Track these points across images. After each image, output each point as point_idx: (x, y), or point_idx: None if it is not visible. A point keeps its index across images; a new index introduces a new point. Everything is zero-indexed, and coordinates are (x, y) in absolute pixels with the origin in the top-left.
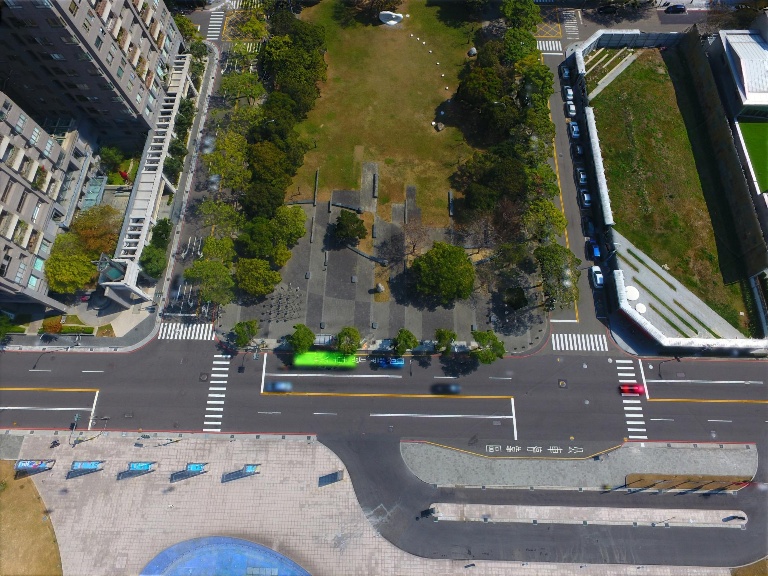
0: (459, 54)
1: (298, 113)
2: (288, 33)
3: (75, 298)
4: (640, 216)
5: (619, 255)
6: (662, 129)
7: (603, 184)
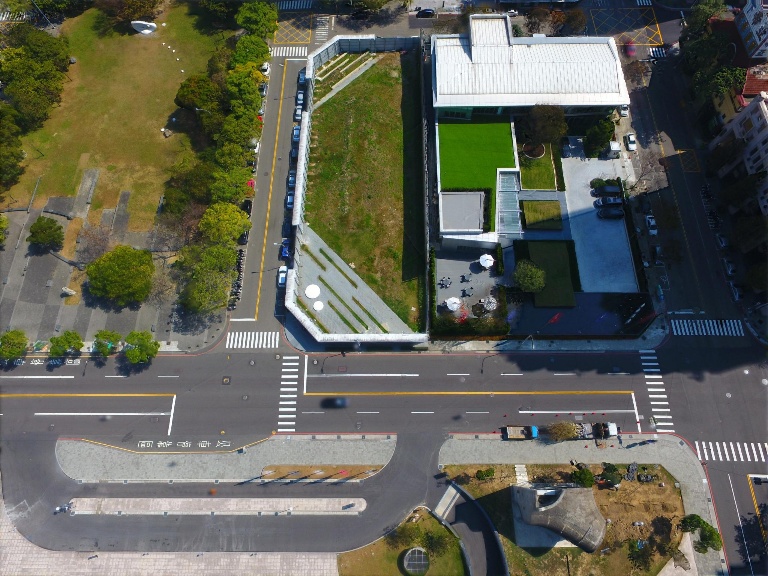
0: (206, 61)
1: (35, 122)
2: (24, 44)
3: None
4: (337, 216)
5: (310, 255)
6: (378, 131)
7: (299, 186)
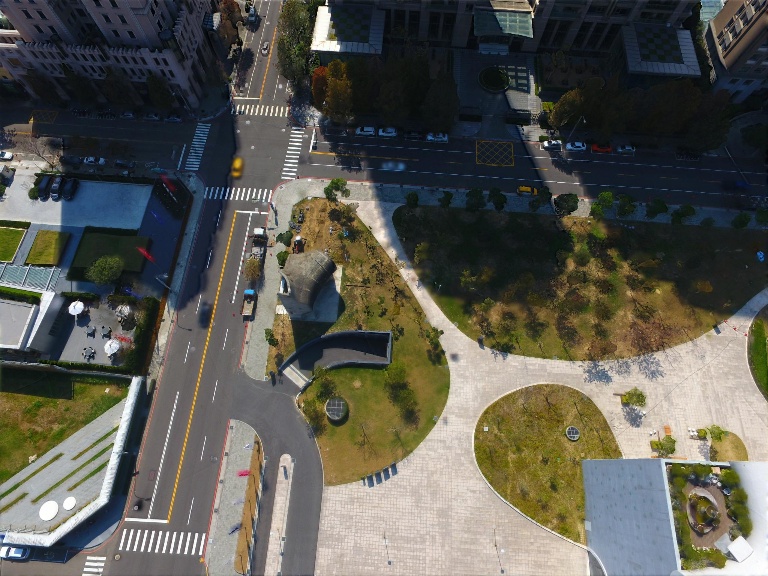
0: None
1: None
2: None
3: None
4: None
5: None
6: None
7: None
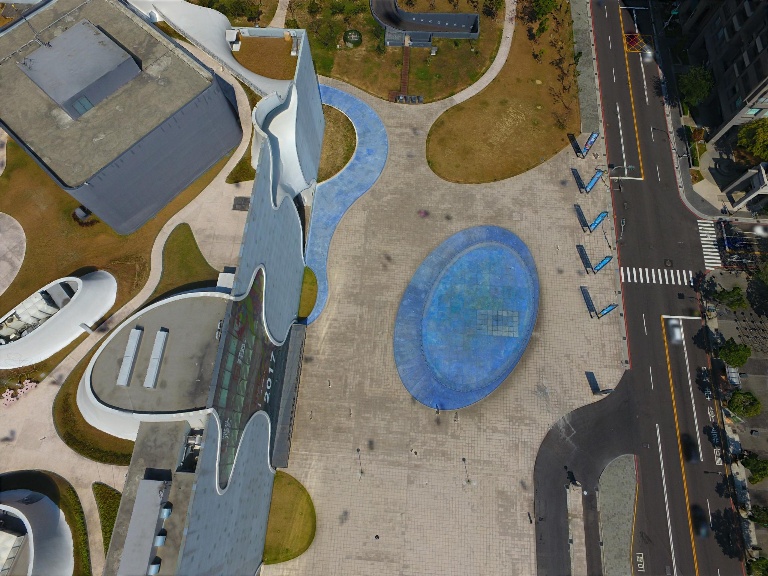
0: None
1: None
2: None
3: (722, 147)
4: None
5: None
6: None
7: None
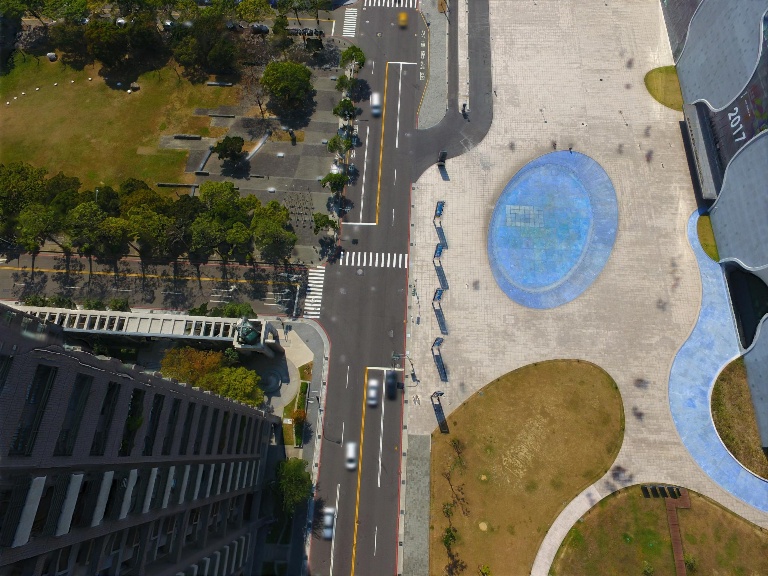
0: (50, 68)
1: None
2: None
3: None
4: None
5: None
6: None
7: None
